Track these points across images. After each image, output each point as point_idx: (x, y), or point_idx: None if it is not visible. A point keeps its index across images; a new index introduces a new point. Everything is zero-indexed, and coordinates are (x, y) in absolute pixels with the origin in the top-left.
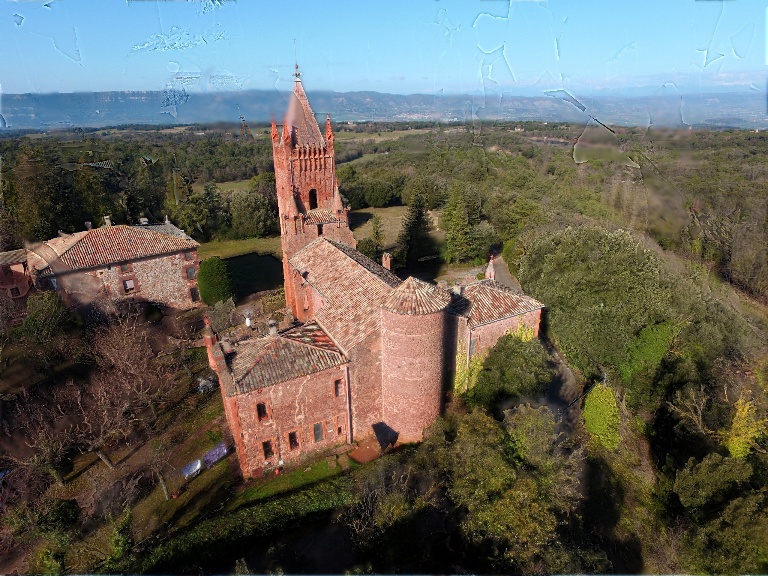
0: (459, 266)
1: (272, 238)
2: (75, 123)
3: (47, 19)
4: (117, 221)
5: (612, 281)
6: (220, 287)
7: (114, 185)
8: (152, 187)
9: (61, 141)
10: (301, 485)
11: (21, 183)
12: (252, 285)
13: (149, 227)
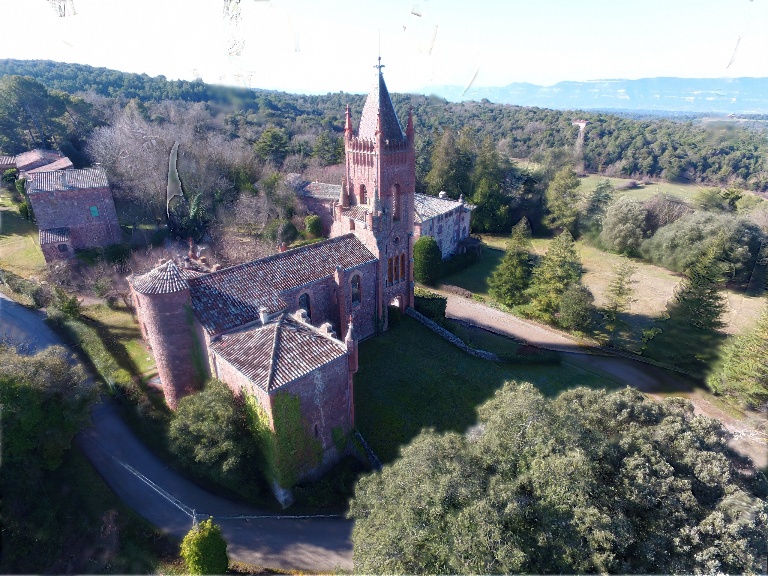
0: (725, 408)
1: (633, 262)
2: (447, 107)
3: (419, 26)
4: (470, 193)
5: (389, 473)
6: (416, 263)
7: (472, 162)
8: (543, 173)
9: (437, 121)
10: (133, 360)
11: (439, 150)
12: (486, 283)
13: (430, 199)
